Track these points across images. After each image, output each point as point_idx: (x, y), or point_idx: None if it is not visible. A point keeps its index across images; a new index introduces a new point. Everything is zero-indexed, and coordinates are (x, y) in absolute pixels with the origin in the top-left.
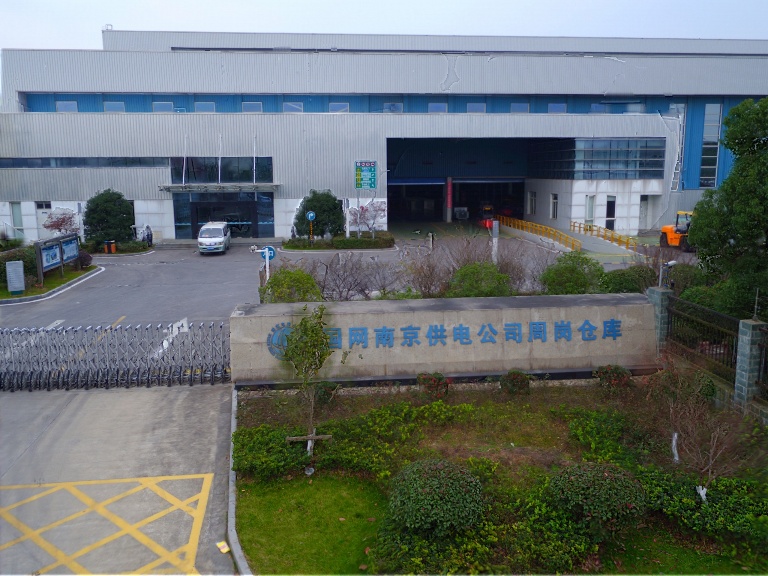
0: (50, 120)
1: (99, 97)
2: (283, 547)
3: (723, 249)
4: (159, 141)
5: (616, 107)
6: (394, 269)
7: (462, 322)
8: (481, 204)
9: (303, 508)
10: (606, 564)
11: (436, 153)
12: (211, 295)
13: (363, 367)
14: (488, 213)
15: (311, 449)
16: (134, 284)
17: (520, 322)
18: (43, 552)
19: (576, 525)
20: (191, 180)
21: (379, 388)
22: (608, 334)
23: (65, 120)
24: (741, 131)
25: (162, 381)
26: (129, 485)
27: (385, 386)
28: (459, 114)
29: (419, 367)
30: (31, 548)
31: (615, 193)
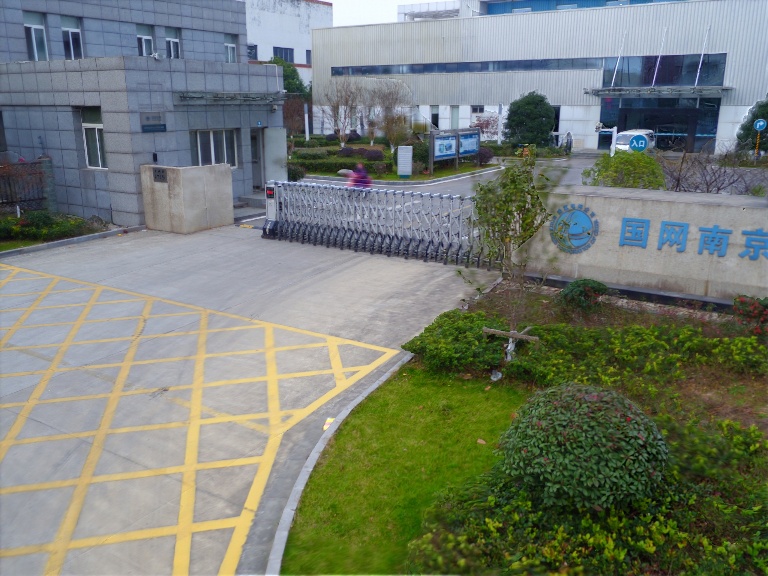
0: (493, 23)
1: (553, 1)
2: (380, 446)
3: None
4: (595, 40)
5: None
6: None
7: None
8: None
9: (448, 413)
10: None
11: None
12: None
13: (673, 278)
14: None
15: (509, 350)
16: None
17: None
18: (191, 373)
19: None
20: (624, 83)
21: (687, 310)
22: None
23: (506, 22)
24: None
25: (442, 258)
26: (315, 339)
27: None
28: None
29: (763, 293)
30: (187, 367)
31: None
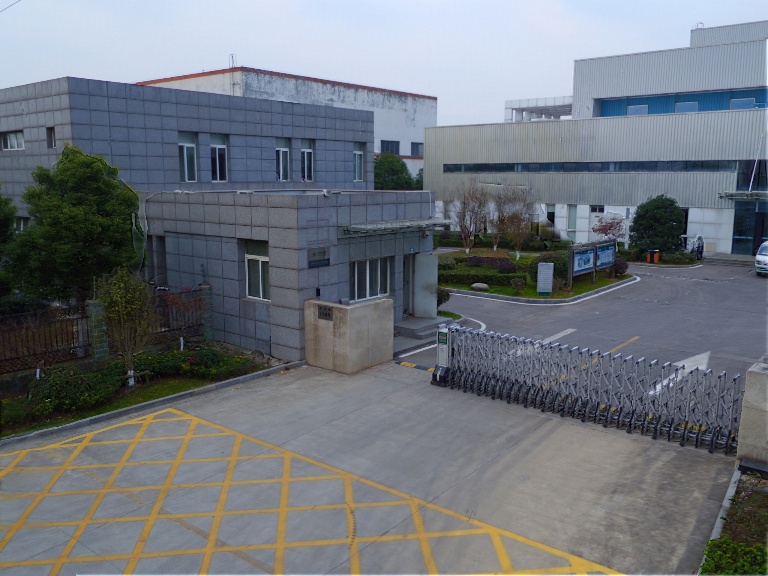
0: (615, 124)
1: (672, 98)
2: None
3: None
4: (728, 142)
5: None
6: None
7: None
8: None
9: None
10: None
11: None
12: (752, 328)
13: None
14: None
15: None
16: (664, 300)
17: None
18: None
19: None
20: (761, 187)
21: None
22: None
23: (630, 123)
24: None
25: (647, 429)
26: (556, 560)
27: None
28: None
29: None
30: None
31: None
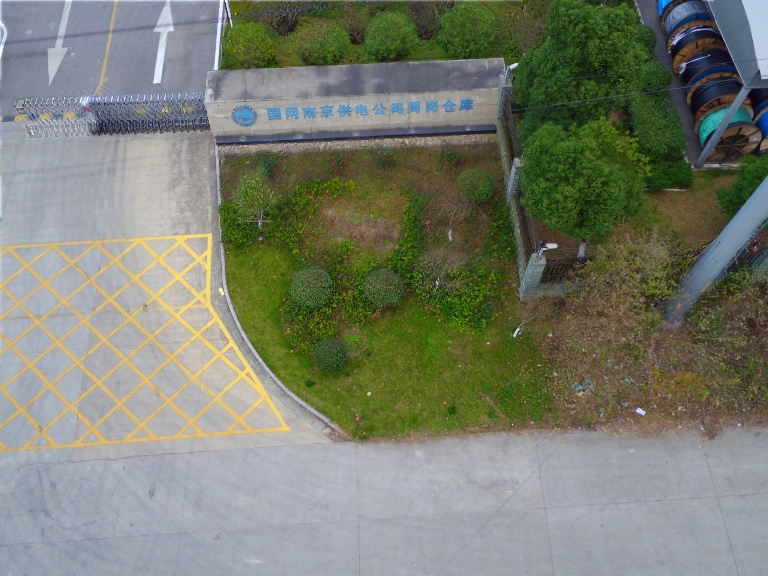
0: None
1: None
2: (247, 296)
3: None
4: None
5: None
6: None
7: None
8: None
9: (257, 268)
10: (382, 315)
11: None
12: None
13: (297, 129)
14: None
15: (260, 226)
16: None
17: (402, 102)
18: (144, 291)
19: None
20: None
21: (307, 144)
22: (463, 108)
23: None
24: (552, 29)
25: (169, 127)
26: (171, 242)
27: (311, 142)
28: None
29: (334, 128)
30: (138, 288)
31: None
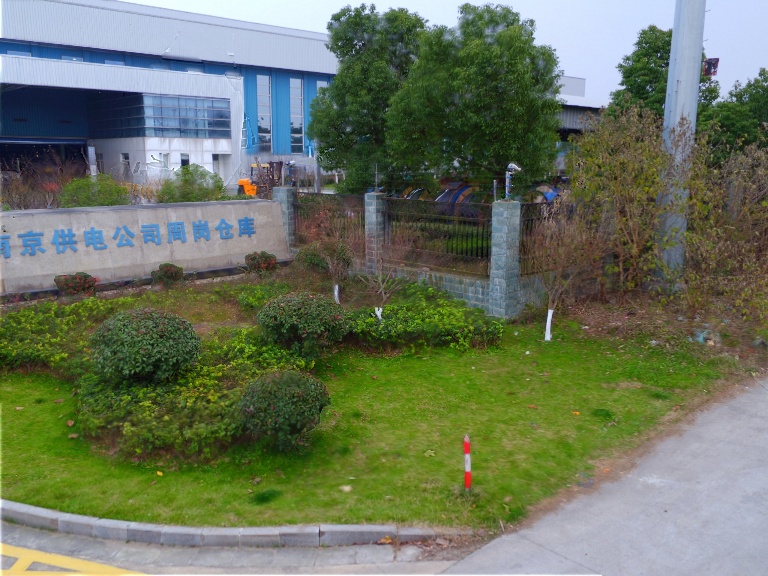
0: None
1: None
2: None
3: (338, 142)
4: None
5: (180, 65)
6: None
7: (93, 225)
8: None
9: None
10: (322, 378)
11: None
12: None
13: None
14: None
15: None
16: None
17: (157, 223)
18: None
19: (289, 351)
20: None
21: None
22: (244, 232)
23: None
24: (344, 32)
25: None
26: None
27: (7, 303)
28: (4, 55)
29: (47, 279)
30: None
31: (188, 151)
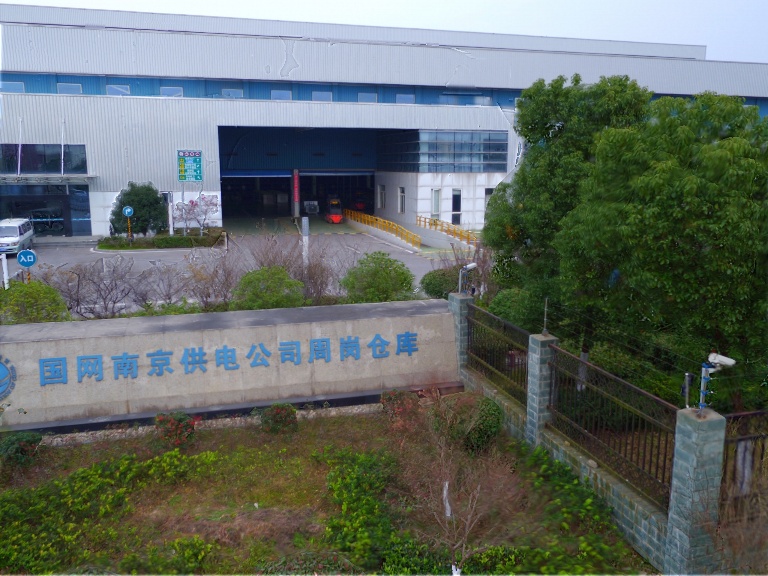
0: None
1: None
2: None
3: (519, 251)
4: None
5: (459, 99)
6: (183, 275)
7: (226, 343)
8: (328, 198)
9: None
10: None
11: (281, 144)
12: None
13: (97, 405)
14: (335, 207)
15: None
16: None
17: (298, 340)
18: None
19: None
20: None
21: (116, 431)
22: (402, 349)
23: None
24: (532, 115)
25: None
26: None
27: None
28: (297, 102)
29: (172, 401)
30: None
31: (460, 187)
